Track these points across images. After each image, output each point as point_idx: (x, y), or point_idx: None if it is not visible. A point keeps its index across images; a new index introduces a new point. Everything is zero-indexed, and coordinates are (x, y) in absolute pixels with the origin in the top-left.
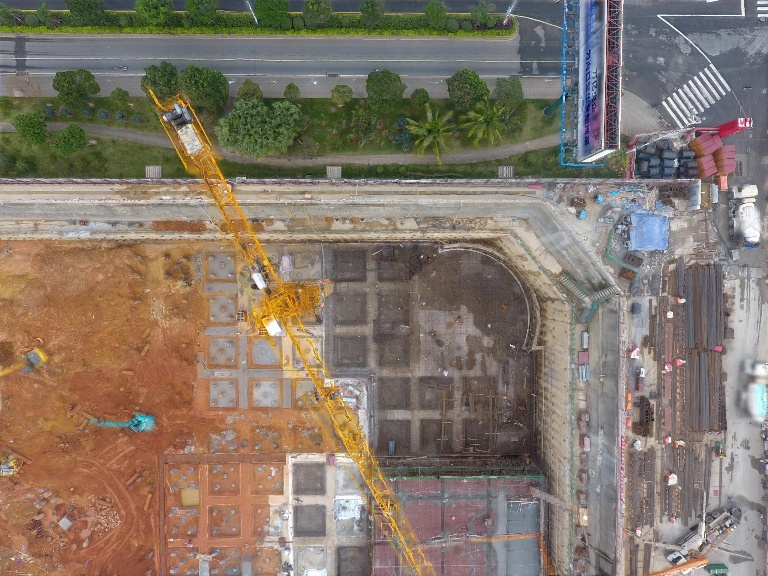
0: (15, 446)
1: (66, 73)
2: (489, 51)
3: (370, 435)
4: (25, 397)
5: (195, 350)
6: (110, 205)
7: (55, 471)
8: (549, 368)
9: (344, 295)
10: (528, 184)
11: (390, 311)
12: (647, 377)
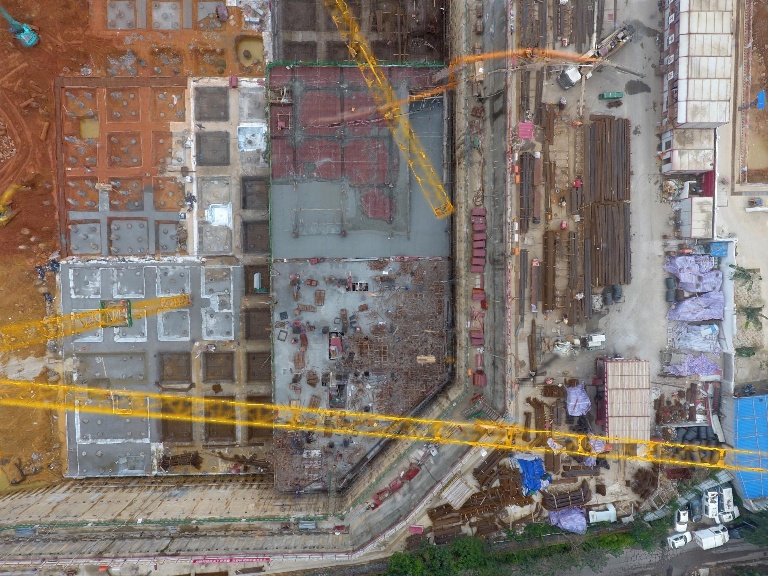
0: None
1: None
2: None
3: (274, 56)
4: None
5: None
6: None
7: None
8: None
9: None
10: None
11: None
12: None
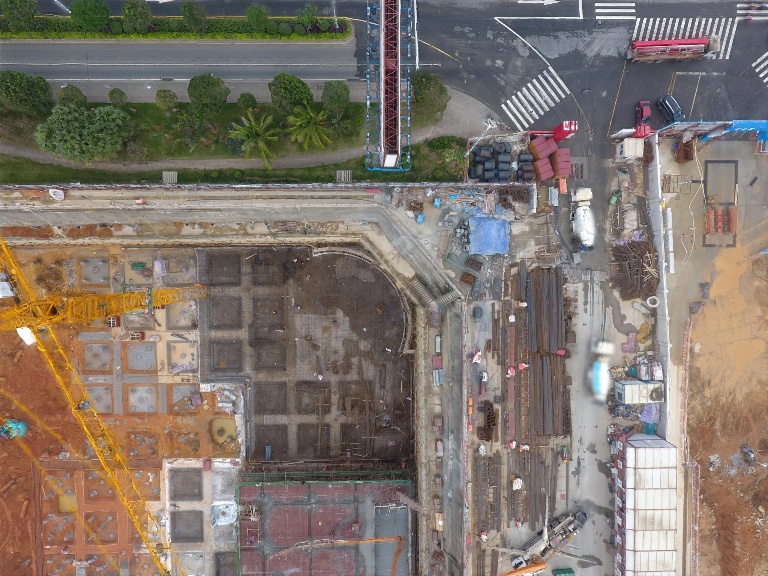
0: None
1: None
2: (325, 55)
3: (246, 440)
4: None
5: (69, 356)
6: None
7: None
8: (417, 372)
9: (220, 299)
10: (365, 188)
11: (266, 315)
12: (491, 381)
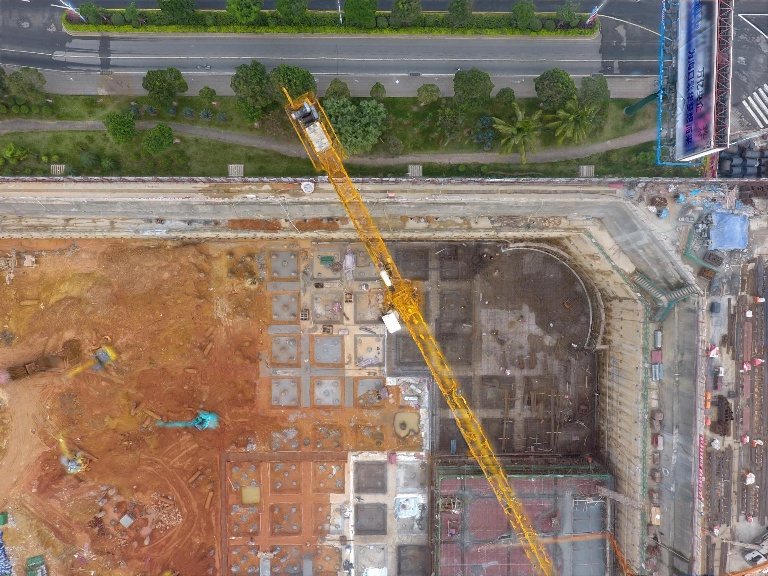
0: (82, 444)
1: (157, 72)
2: (570, 50)
3: (432, 434)
4: (92, 395)
5: (258, 348)
6: (192, 203)
7: (119, 469)
8: (615, 367)
9: None
10: (609, 183)
11: (452, 310)
12: (725, 376)
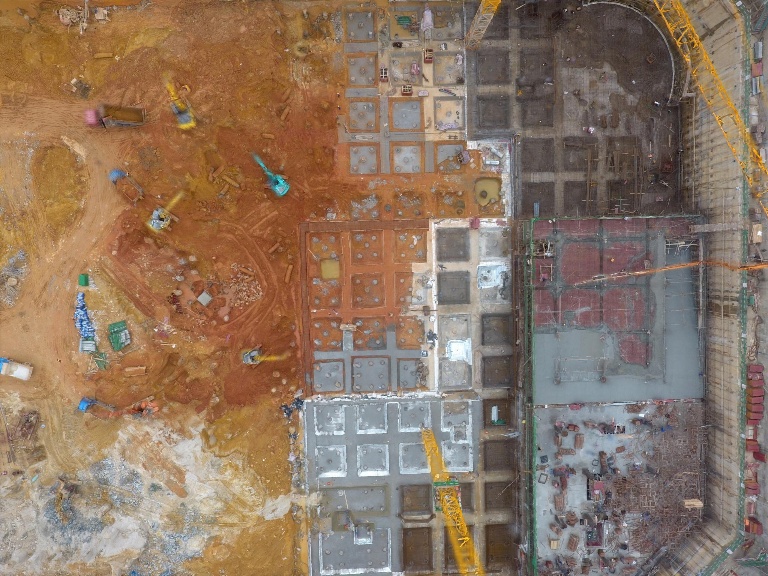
0: (162, 202)
1: None
2: None
3: (514, 197)
4: (173, 148)
5: (335, 113)
6: None
7: (198, 236)
8: (705, 108)
9: (485, 55)
10: None
11: (532, 71)
12: None
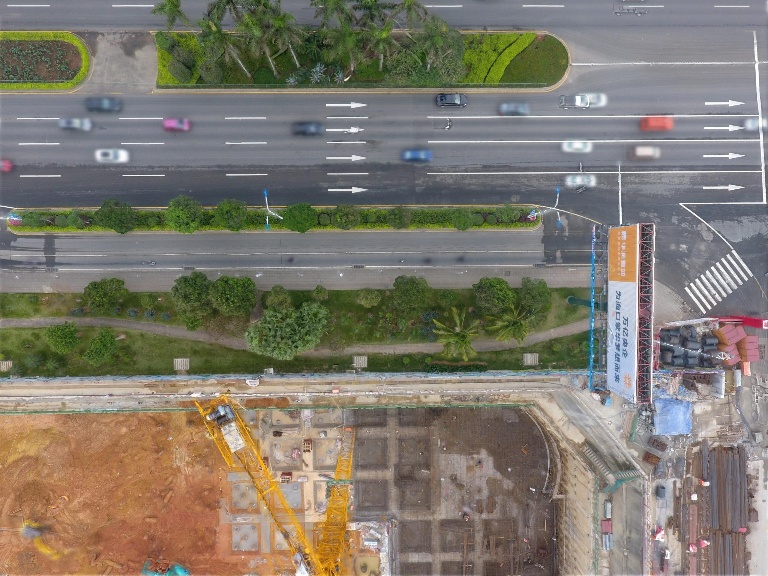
0: None
1: (97, 284)
2: (513, 241)
3: None
4: (50, 553)
5: (217, 496)
6: (139, 397)
7: None
8: (570, 521)
9: (365, 439)
10: None
11: (411, 454)
12: (672, 557)
